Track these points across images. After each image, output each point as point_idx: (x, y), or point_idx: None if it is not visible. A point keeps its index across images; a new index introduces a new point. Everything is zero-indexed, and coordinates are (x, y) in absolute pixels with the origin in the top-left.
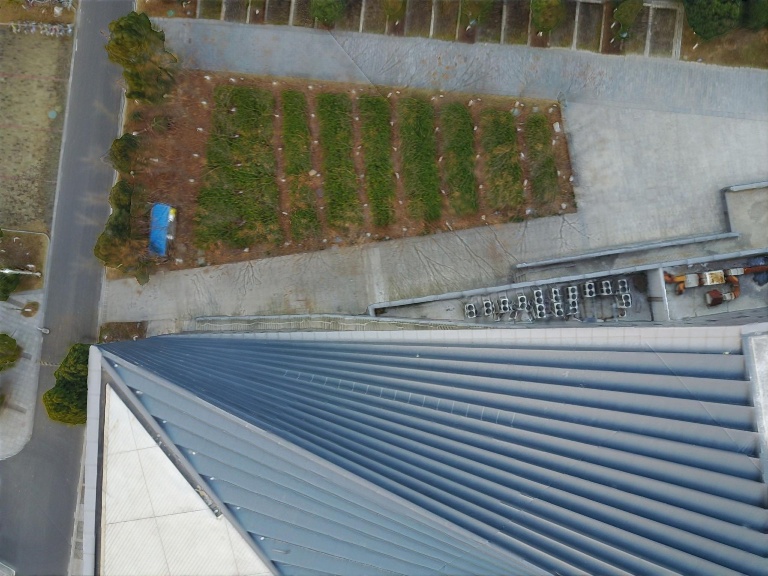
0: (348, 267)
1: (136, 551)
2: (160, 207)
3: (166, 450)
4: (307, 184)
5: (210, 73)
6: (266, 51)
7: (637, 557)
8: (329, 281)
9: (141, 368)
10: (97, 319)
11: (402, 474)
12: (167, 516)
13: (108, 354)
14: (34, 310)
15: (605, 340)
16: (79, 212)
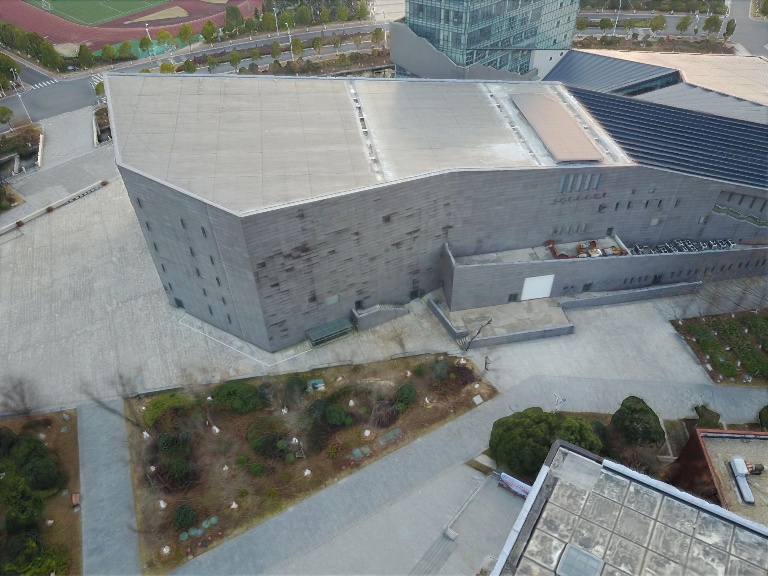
0: None
1: None
2: None
3: None
4: None
5: None
6: None
7: None
8: None
9: None
10: None
11: (766, 133)
12: None
13: None
14: None
15: None
16: None
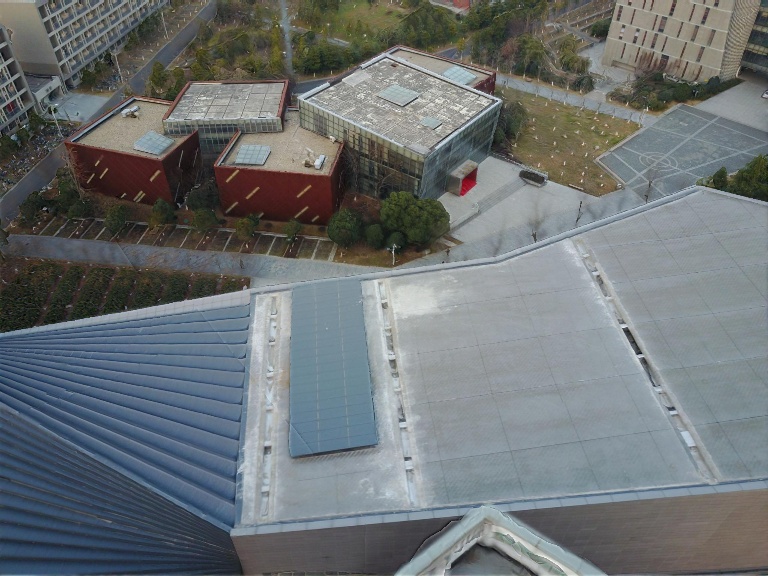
0: None
1: None
2: None
3: None
4: (36, 265)
5: (30, 257)
6: (73, 250)
7: (133, 426)
8: None
9: None
10: None
11: None
12: None
13: None
14: None
15: (173, 311)
16: None
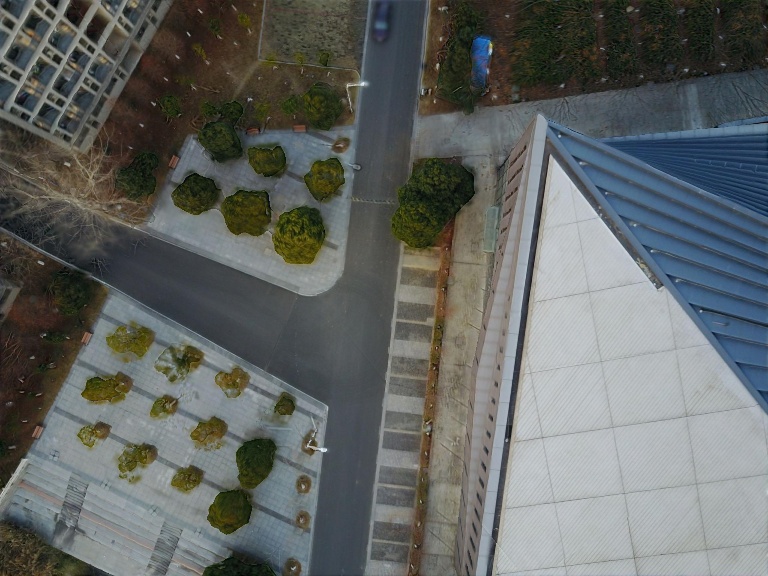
0: (664, 103)
1: (564, 329)
2: (480, 40)
3: (607, 222)
4: None
5: None
6: None
7: None
8: (645, 117)
9: (588, 137)
10: (409, 155)
11: None
12: (602, 291)
13: (554, 124)
14: (346, 146)
15: None
16: (390, 48)
